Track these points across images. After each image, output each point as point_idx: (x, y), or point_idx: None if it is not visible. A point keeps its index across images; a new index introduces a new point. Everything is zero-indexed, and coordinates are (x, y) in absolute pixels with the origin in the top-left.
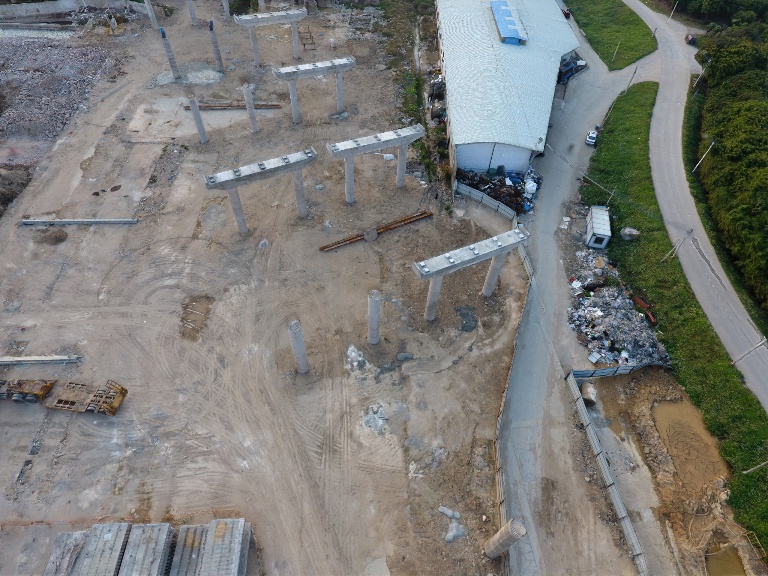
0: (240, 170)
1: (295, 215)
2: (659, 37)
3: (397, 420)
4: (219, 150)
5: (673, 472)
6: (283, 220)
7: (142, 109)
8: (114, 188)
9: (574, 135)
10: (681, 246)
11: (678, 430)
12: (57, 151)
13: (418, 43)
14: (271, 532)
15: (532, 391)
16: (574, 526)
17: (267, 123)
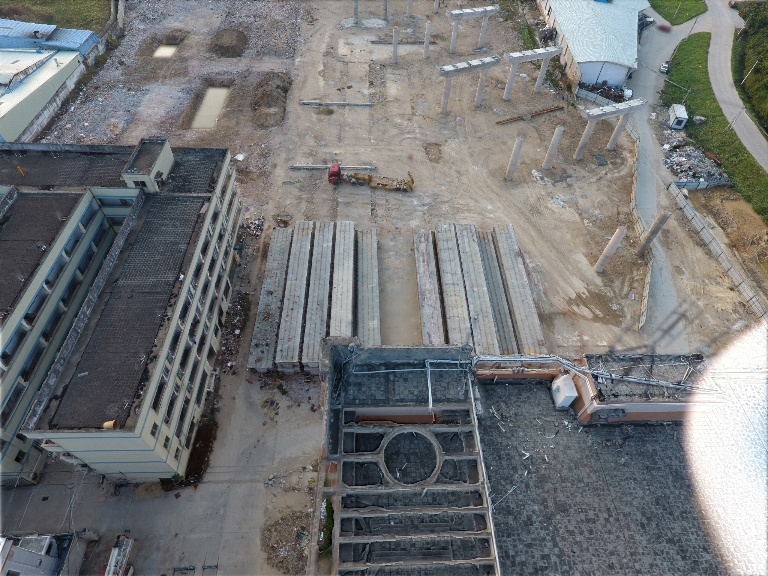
0: (456, 65)
1: (473, 105)
2: (708, 2)
3: (571, 202)
4: (406, 68)
5: (737, 227)
6: (466, 108)
7: (342, 42)
8: (348, 87)
9: (651, 66)
10: (735, 124)
11: (738, 212)
12: (299, 65)
13: (520, 5)
14: (517, 241)
15: (648, 194)
16: (682, 247)
17: (432, 53)
